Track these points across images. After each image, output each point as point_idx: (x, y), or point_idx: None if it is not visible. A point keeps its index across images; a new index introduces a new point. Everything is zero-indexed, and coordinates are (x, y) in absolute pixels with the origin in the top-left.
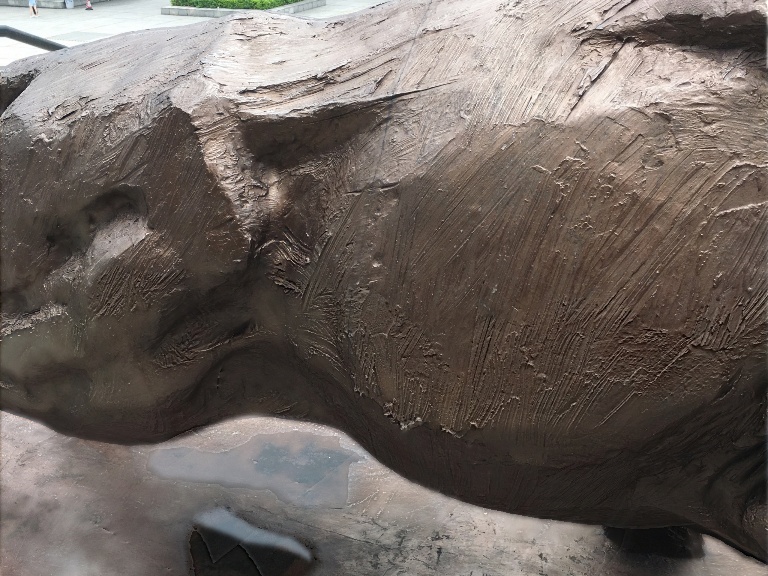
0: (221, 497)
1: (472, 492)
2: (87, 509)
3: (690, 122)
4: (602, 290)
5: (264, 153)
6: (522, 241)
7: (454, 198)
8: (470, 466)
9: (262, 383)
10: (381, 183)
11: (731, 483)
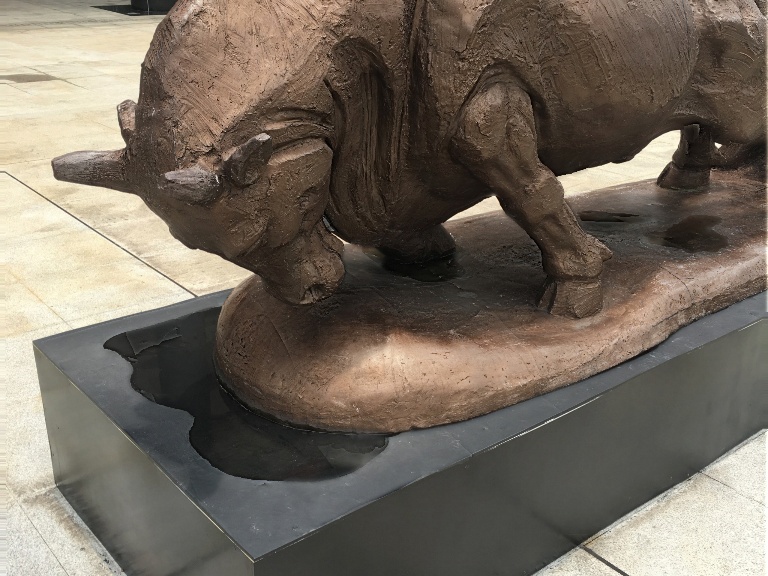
0: (665, 222)
1: None
2: (672, 204)
3: None
4: None
5: None
6: None
7: None
8: None
9: None
10: None
11: None
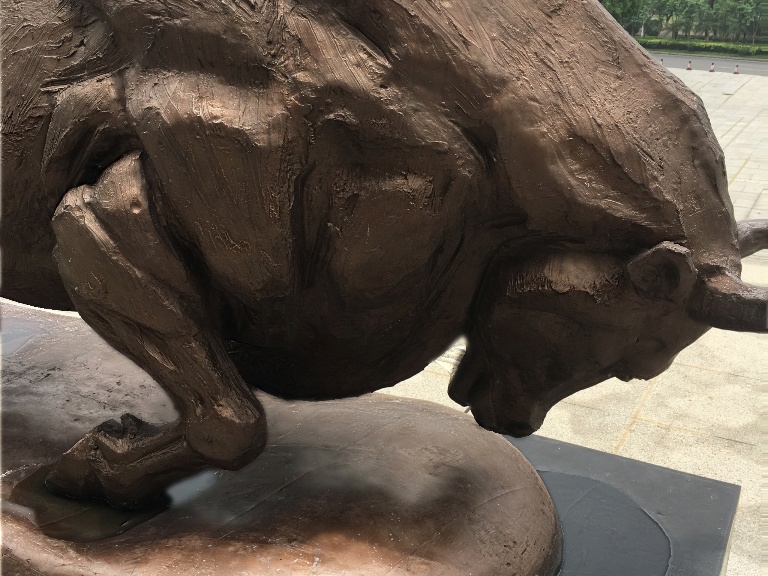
0: None
1: None
2: None
3: (9, 3)
4: None
5: None
6: None
7: None
8: None
9: None
10: None
11: None
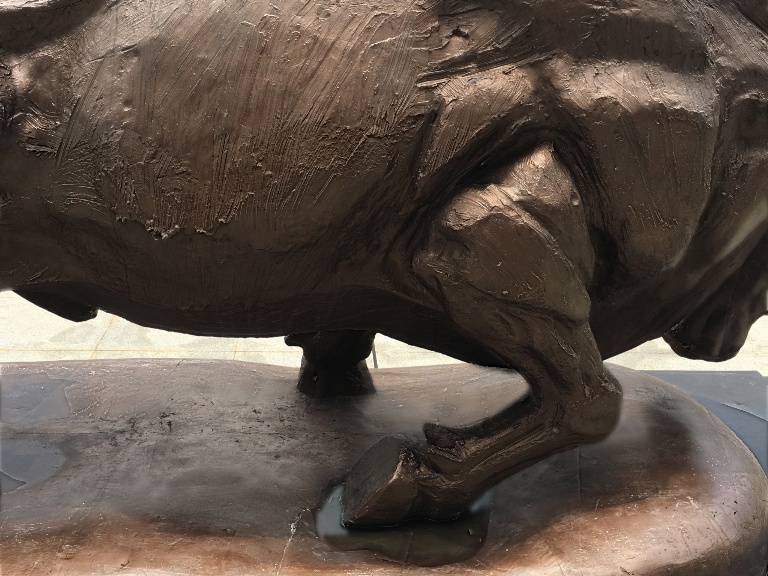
0: None
1: (218, 297)
2: None
3: None
4: (303, 104)
5: (3, 40)
6: (241, 76)
7: (185, 50)
8: (217, 267)
9: (11, 256)
10: (121, 47)
11: (400, 253)
